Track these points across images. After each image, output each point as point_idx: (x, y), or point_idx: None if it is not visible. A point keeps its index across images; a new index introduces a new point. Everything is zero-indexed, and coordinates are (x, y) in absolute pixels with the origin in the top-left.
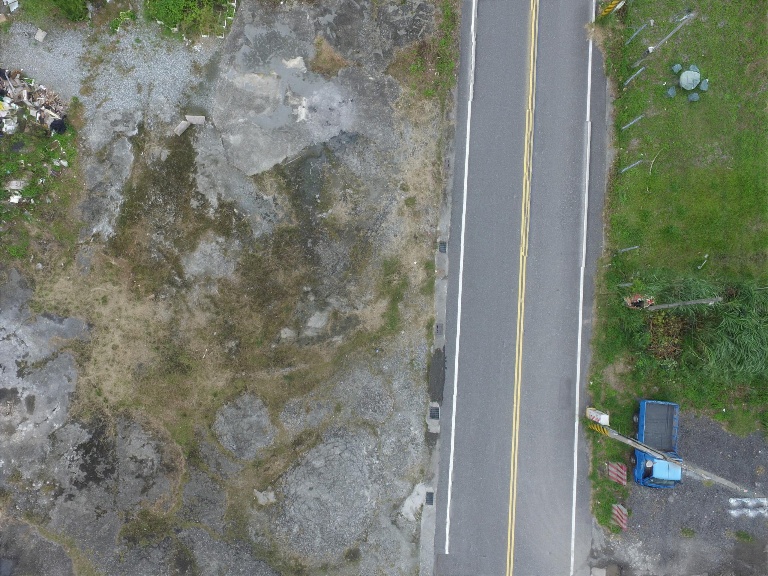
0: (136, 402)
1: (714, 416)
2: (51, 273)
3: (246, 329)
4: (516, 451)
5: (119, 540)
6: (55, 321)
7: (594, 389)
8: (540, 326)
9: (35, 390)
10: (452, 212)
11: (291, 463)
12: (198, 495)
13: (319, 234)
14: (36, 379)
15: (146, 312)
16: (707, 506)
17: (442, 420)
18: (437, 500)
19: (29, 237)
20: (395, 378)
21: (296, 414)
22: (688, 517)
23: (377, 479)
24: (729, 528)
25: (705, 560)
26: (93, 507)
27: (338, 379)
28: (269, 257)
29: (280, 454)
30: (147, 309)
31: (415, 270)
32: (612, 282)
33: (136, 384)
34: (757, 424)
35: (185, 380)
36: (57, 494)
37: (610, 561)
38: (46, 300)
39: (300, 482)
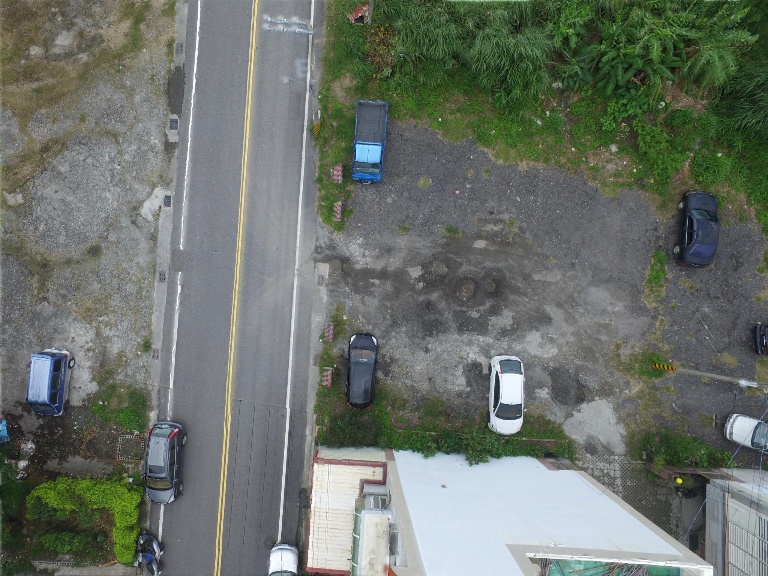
0: None
1: (430, 125)
2: None
3: None
4: (246, 155)
5: None
6: None
7: (321, 101)
8: (272, 44)
9: None
10: None
11: (38, 168)
12: None
13: None
14: None
15: None
16: (422, 206)
17: (180, 130)
18: (174, 202)
19: None
20: (137, 92)
21: (43, 124)
22: (405, 216)
23: (118, 183)
24: (441, 226)
25: (419, 255)
26: None
27: (83, 92)
28: None
29: (28, 160)
30: None
31: None
32: (338, 3)
33: None
34: (470, 132)
35: None
36: None
37: (333, 256)
38: None
39: (47, 185)
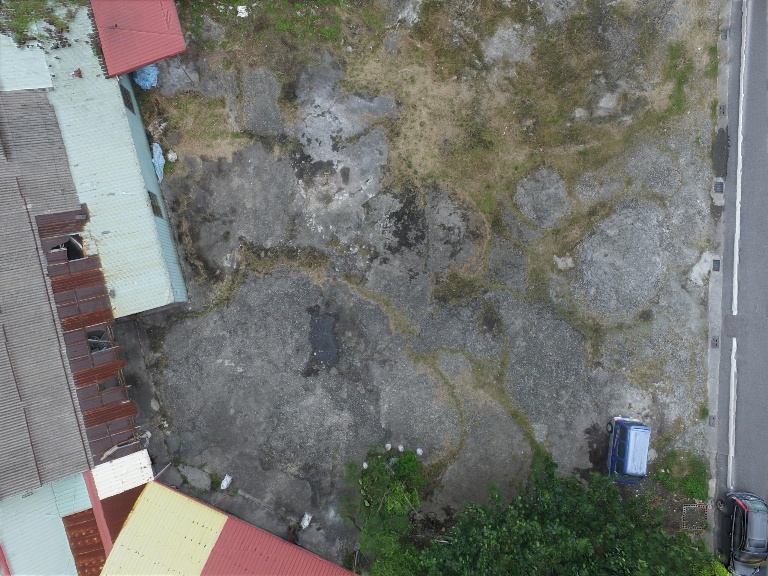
0: (443, 174)
1: None
2: (361, 55)
3: (543, 108)
4: None
5: (431, 300)
6: (366, 100)
7: None
8: None
9: (349, 163)
10: (733, 2)
11: (587, 232)
12: (502, 260)
13: (609, 21)
14: (350, 152)
15: (450, 92)
16: None
17: (726, 194)
18: (724, 266)
19: (341, 21)
20: (682, 155)
21: (591, 187)
22: None
23: (668, 247)
24: None
25: None
26: (406, 269)
27: (629, 155)
28: (563, 42)
29: (577, 223)
30: (451, 89)
31: (699, 55)
32: None
33: (442, 158)
34: None
35: (487, 155)
36: (372, 257)
37: None
38: (357, 80)
39: (596, 249)
